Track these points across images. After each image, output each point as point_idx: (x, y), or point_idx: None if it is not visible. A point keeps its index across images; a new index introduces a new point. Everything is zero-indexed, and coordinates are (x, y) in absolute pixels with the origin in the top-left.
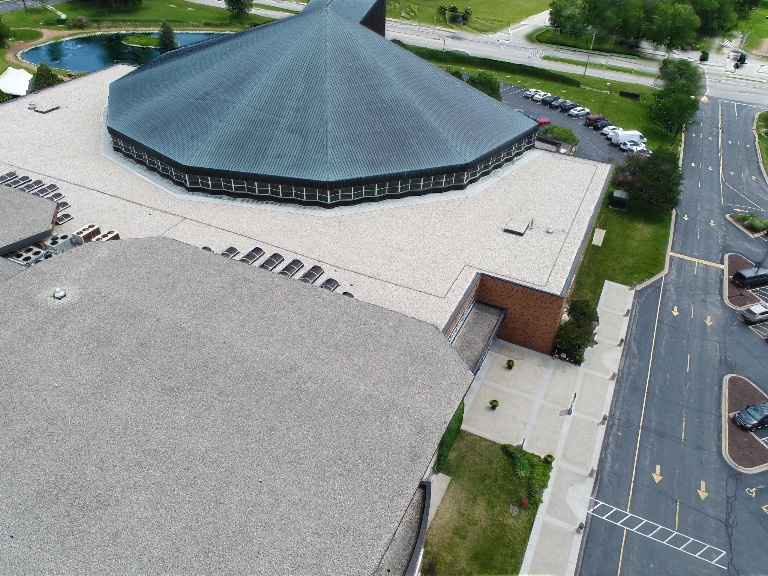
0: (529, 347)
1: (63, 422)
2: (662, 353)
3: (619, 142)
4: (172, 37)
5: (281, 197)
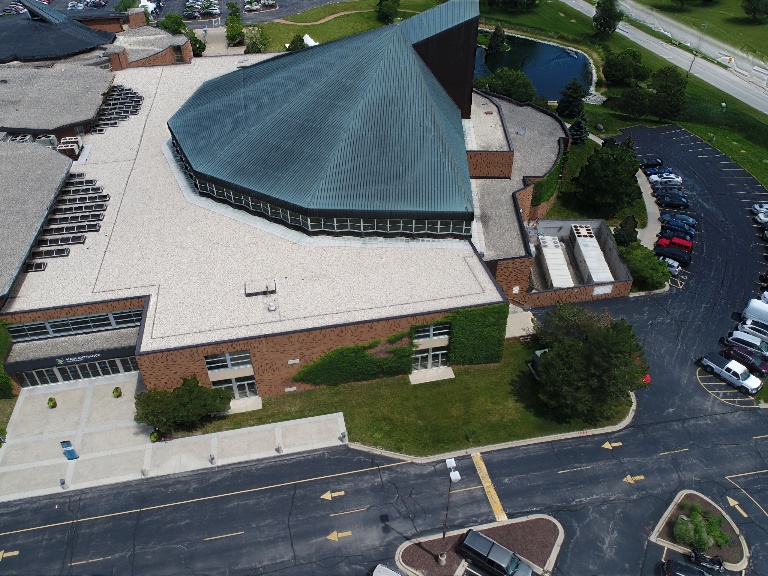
0: None
1: None
2: (227, 505)
3: (748, 317)
4: (499, 41)
5: (189, 172)
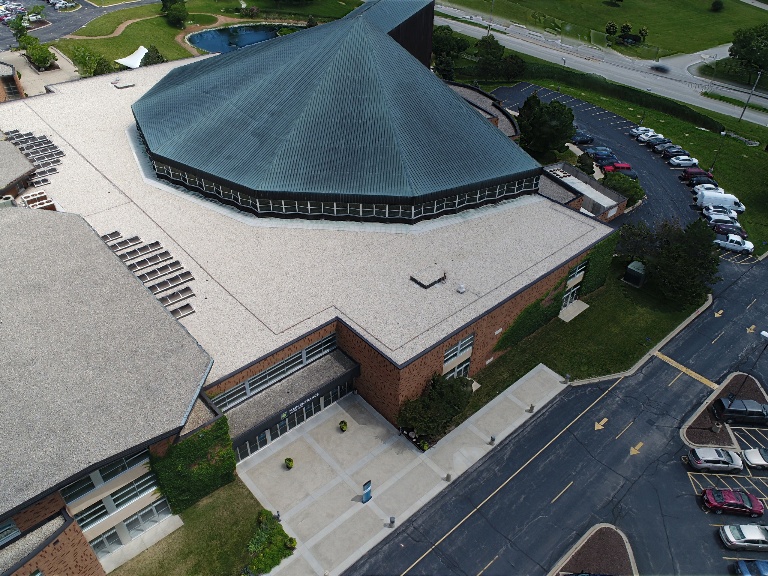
0: (382, 414)
1: None
2: (538, 469)
3: (704, 205)
4: None
5: (222, 197)
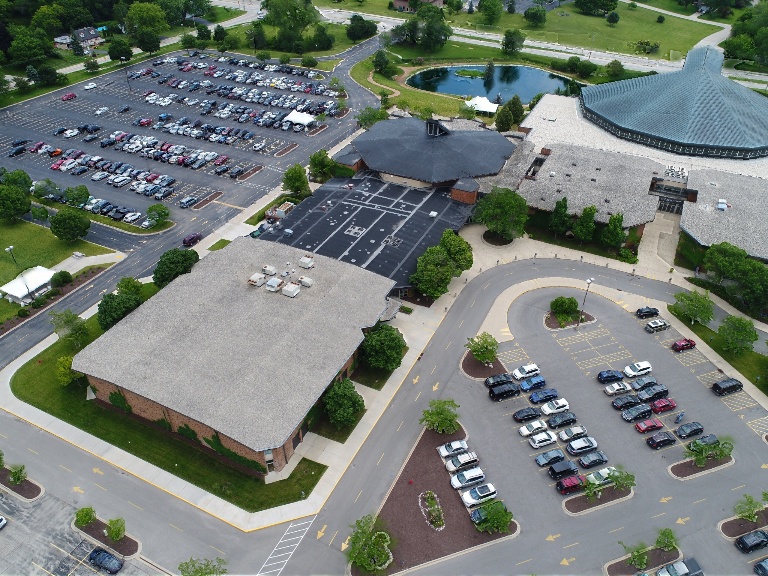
0: None
1: (767, 212)
2: None
3: None
4: None
5: (725, 156)
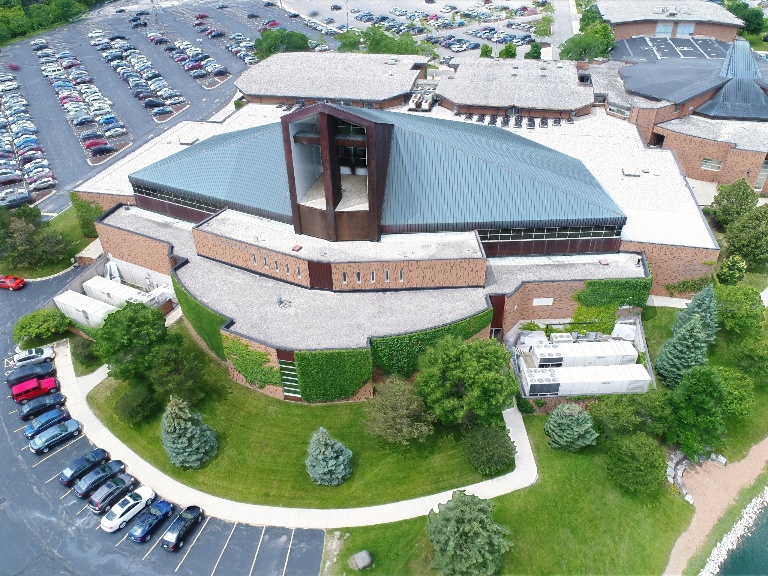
0: None
1: None
2: None
3: None
4: None
5: None
